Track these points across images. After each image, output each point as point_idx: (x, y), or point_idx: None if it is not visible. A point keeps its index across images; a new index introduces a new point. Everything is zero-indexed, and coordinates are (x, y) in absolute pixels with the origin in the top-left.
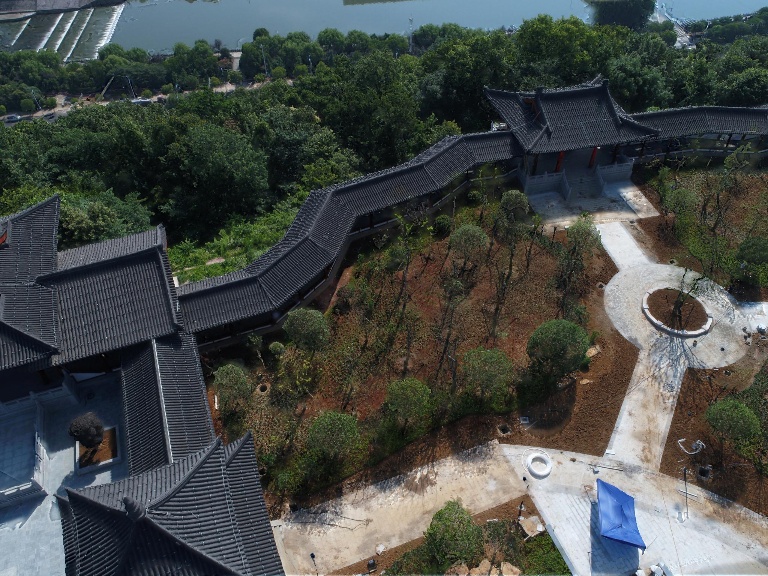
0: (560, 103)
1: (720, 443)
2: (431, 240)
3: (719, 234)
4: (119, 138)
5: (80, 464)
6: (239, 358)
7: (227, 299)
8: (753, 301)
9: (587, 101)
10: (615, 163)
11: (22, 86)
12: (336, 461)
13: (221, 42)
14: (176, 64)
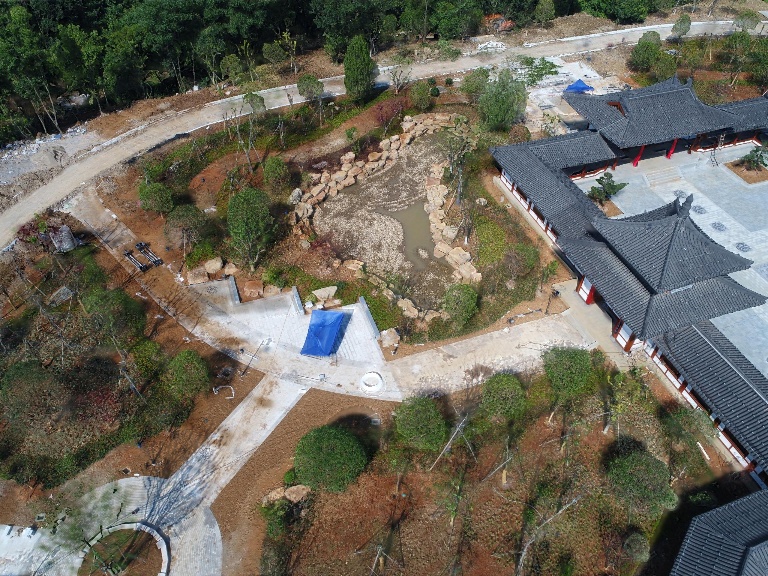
0: None
1: None
2: None
3: None
4: None
5: None
6: (710, 507)
7: None
8: None
9: None
10: None
11: None
12: None
13: None
14: None
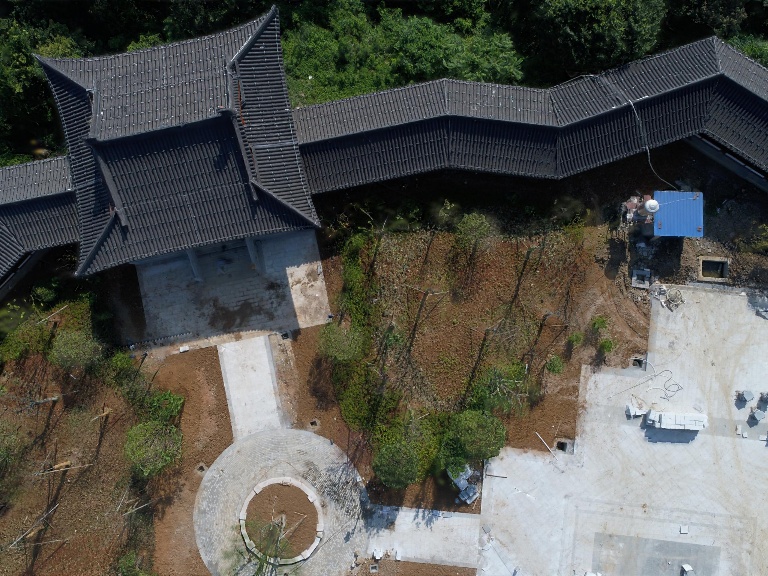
0: (144, 152)
1: None
2: None
3: (389, 387)
4: None
5: None
6: None
7: None
8: (390, 505)
9: (198, 145)
10: None
11: None
12: None
13: None
14: None
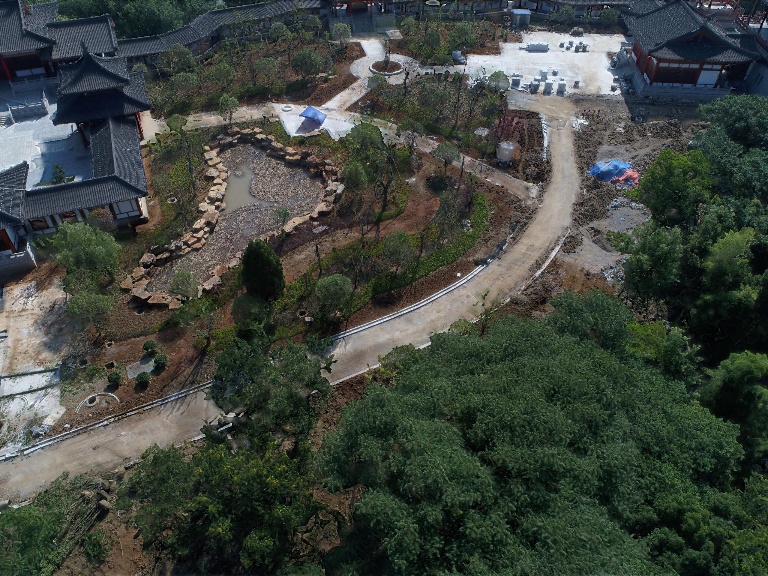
0: None
1: (377, 101)
2: None
3: None
4: None
5: None
6: (149, 79)
7: (143, 45)
8: (430, 65)
9: None
10: (383, 13)
11: None
12: (188, 103)
13: None
14: None
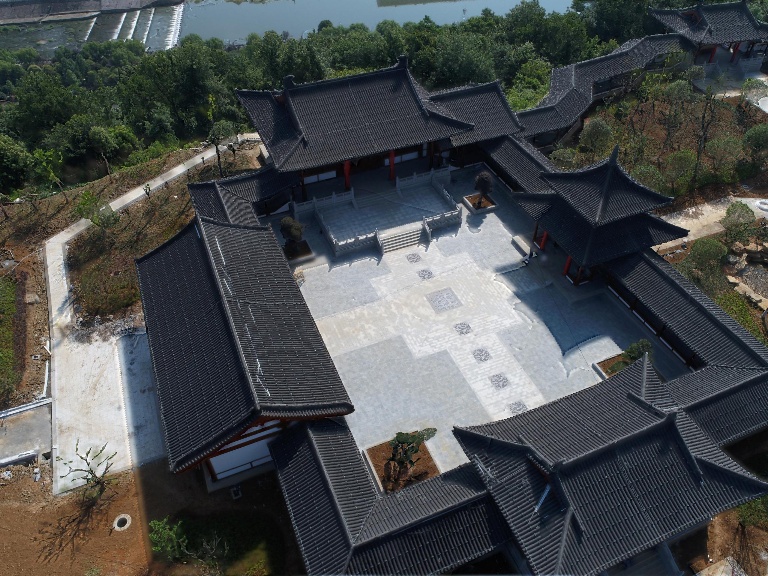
0: (714, 13)
1: None
2: None
3: None
4: (383, 46)
5: (475, 208)
6: None
7: (538, 119)
8: None
9: (732, 12)
10: (752, 57)
11: (116, 71)
12: None
13: (288, 33)
14: (253, 51)
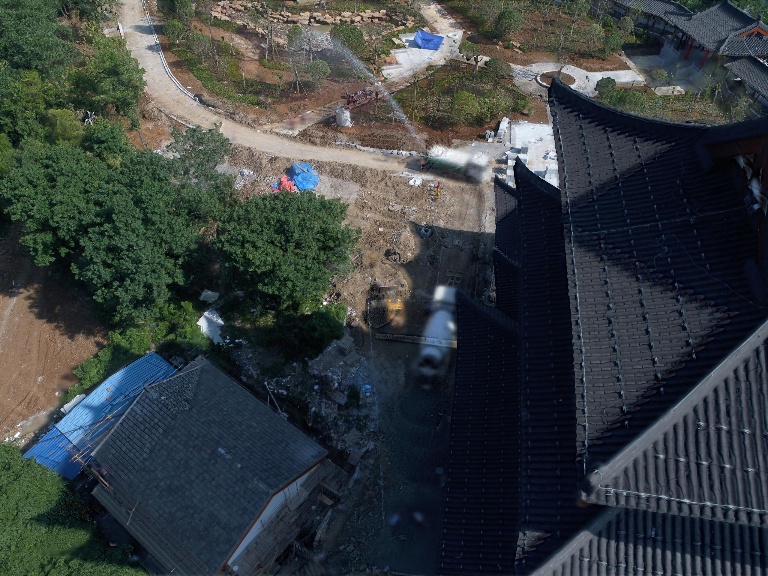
0: (727, 14)
1: None
2: (593, 22)
3: None
4: None
5: None
6: None
7: None
8: None
9: (738, 23)
10: None
11: None
12: None
13: None
14: None
